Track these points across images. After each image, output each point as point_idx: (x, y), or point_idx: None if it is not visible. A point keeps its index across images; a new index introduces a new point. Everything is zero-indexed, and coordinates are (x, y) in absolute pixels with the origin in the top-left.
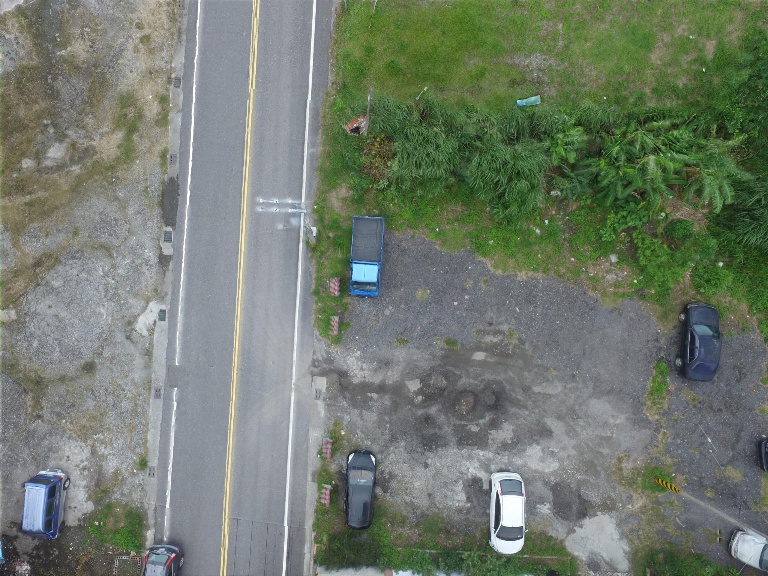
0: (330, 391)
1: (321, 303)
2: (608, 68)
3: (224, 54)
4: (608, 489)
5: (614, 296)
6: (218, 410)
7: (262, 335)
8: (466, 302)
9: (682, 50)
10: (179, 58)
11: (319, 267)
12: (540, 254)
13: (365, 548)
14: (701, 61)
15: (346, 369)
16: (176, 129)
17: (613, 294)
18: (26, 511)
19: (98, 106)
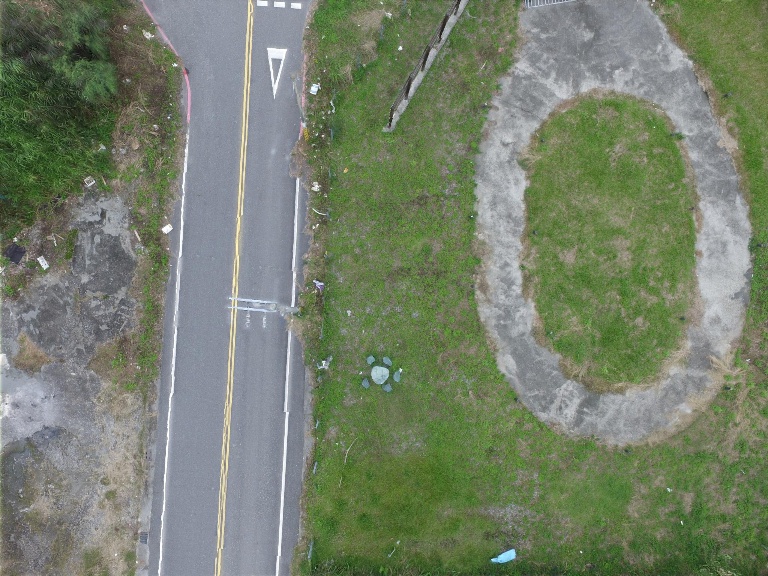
0: None
1: None
2: (584, 520)
3: (192, 510)
4: None
5: None
6: None
7: None
8: None
9: (659, 503)
10: (146, 512)
11: None
12: None
13: None
14: (679, 514)
15: None
16: None
17: None
18: None
19: (62, 566)
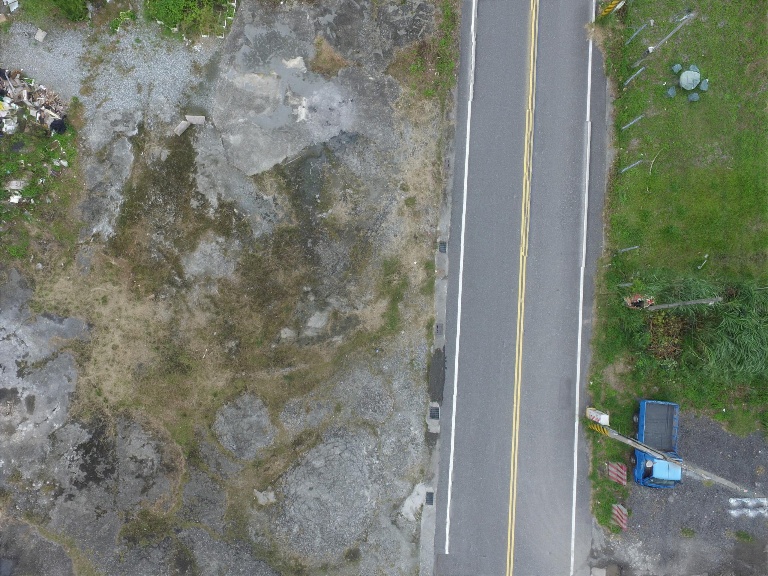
0: None
1: (599, 488)
2: None
3: (493, 218)
4: None
5: None
6: None
7: (537, 522)
8: (756, 489)
9: None
10: (444, 221)
11: (597, 449)
12: None
13: None
14: None
15: (627, 561)
16: (442, 297)
17: None
18: None
19: (361, 272)
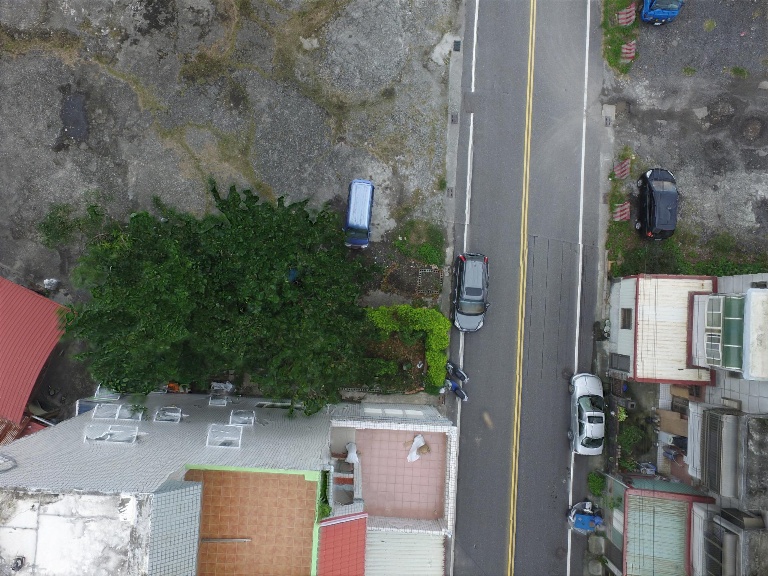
0: (620, 118)
1: (610, 35)
2: None
3: None
4: None
5: None
6: (514, 134)
7: (554, 64)
8: (752, 34)
9: None
10: None
11: (608, 0)
12: None
13: (667, 257)
14: None
15: (635, 97)
16: None
17: None
18: (354, 206)
19: None
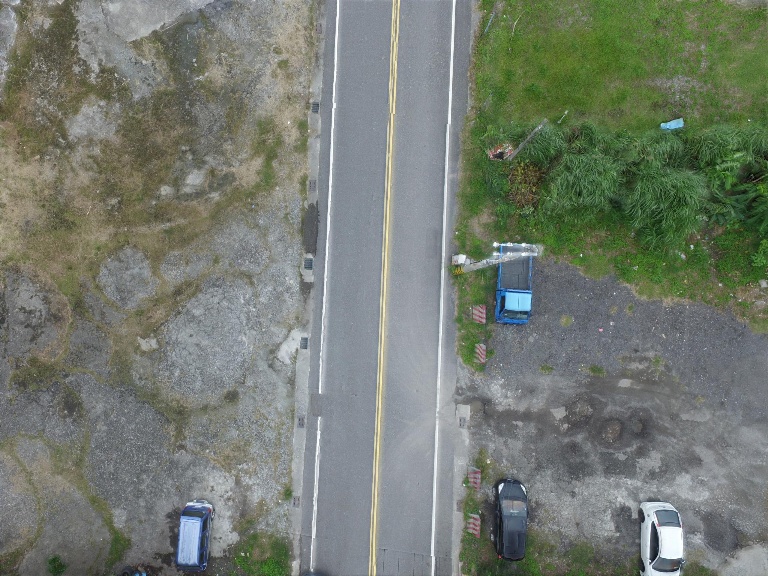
0: (474, 419)
1: (464, 330)
2: (752, 90)
3: (363, 78)
4: (759, 518)
5: (763, 322)
6: (363, 439)
7: (405, 363)
8: (611, 329)
9: None
10: (317, 83)
11: (462, 294)
12: (686, 280)
13: None
14: None
15: (490, 397)
16: (315, 155)
17: (762, 320)
18: (182, 544)
19: (236, 132)
